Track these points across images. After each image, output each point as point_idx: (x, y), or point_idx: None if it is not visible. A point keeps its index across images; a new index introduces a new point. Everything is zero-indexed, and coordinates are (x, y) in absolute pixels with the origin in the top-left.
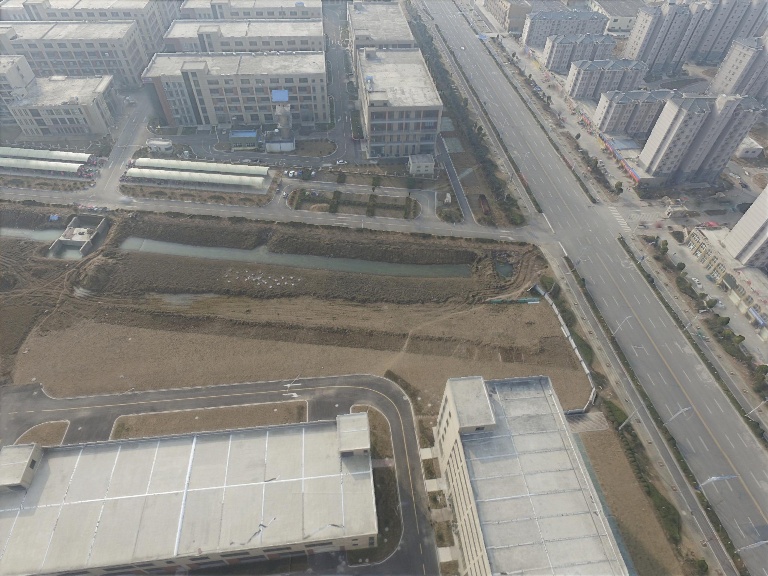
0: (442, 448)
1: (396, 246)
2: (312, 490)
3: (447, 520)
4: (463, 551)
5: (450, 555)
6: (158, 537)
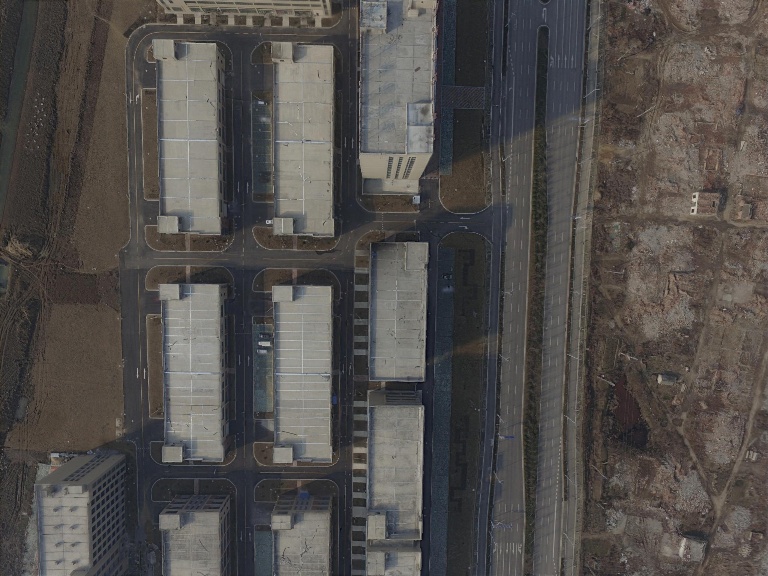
0: (177, 8)
1: (3, 11)
2: (193, 76)
3: (216, 16)
4: (229, 8)
5: (232, 19)
6: (208, 150)
